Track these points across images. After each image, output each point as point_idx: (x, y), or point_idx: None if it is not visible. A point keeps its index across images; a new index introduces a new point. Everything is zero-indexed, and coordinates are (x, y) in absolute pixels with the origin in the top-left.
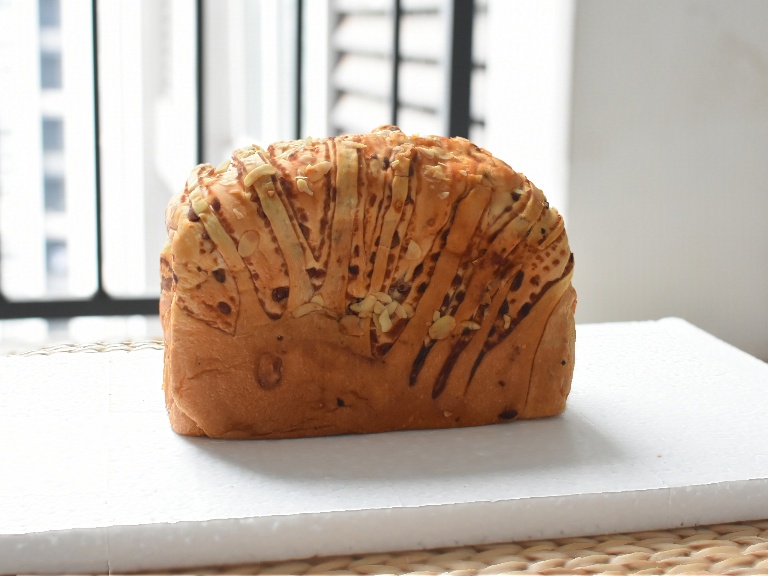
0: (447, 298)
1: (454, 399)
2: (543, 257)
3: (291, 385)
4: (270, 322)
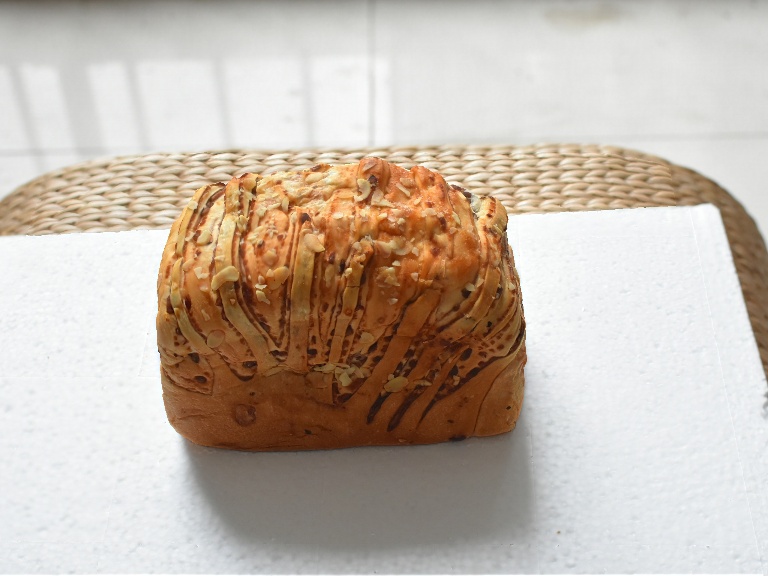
0: (400, 365)
1: (407, 431)
2: (488, 344)
3: (264, 423)
4: (242, 383)
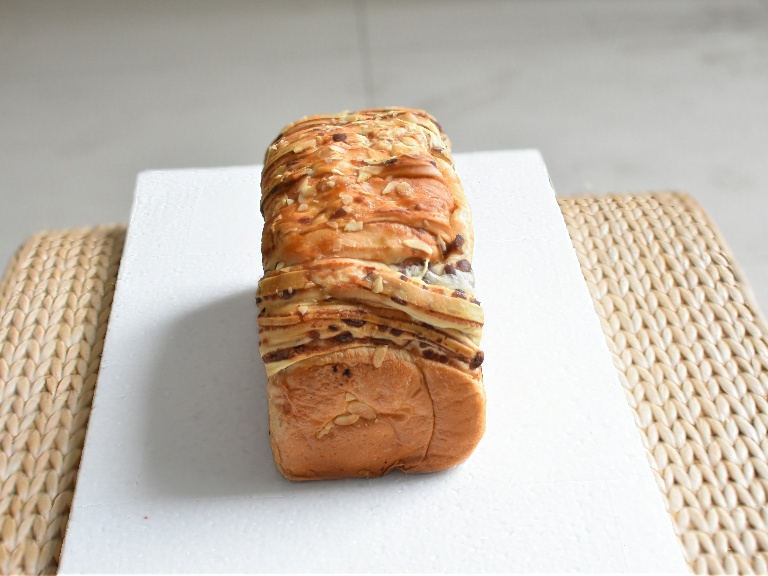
0: None
1: None
2: None
3: None
4: None
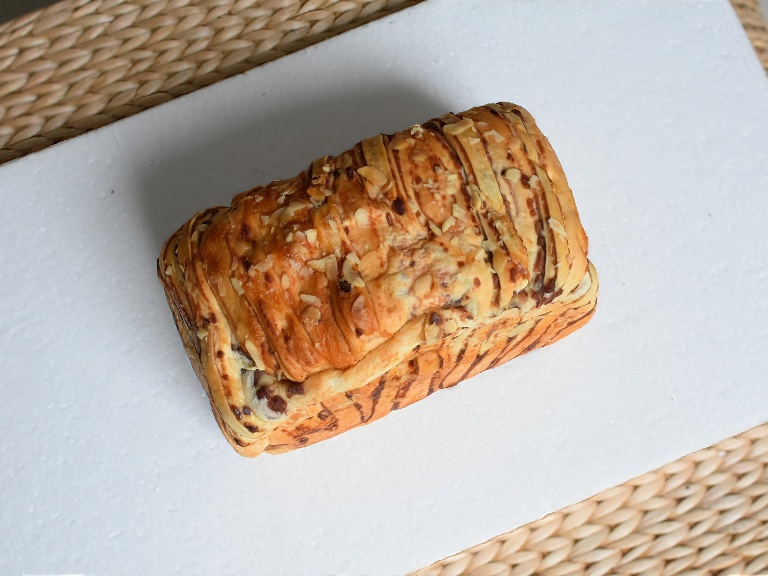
0: None
1: None
2: None
3: None
4: None
